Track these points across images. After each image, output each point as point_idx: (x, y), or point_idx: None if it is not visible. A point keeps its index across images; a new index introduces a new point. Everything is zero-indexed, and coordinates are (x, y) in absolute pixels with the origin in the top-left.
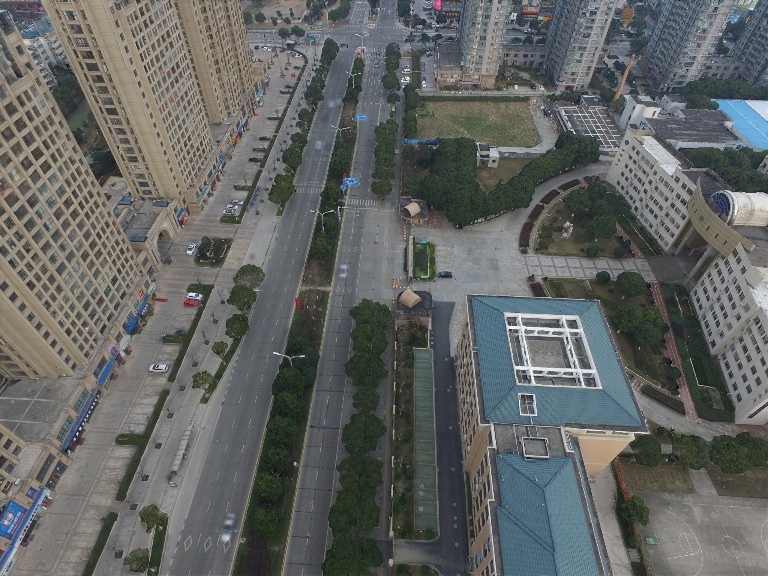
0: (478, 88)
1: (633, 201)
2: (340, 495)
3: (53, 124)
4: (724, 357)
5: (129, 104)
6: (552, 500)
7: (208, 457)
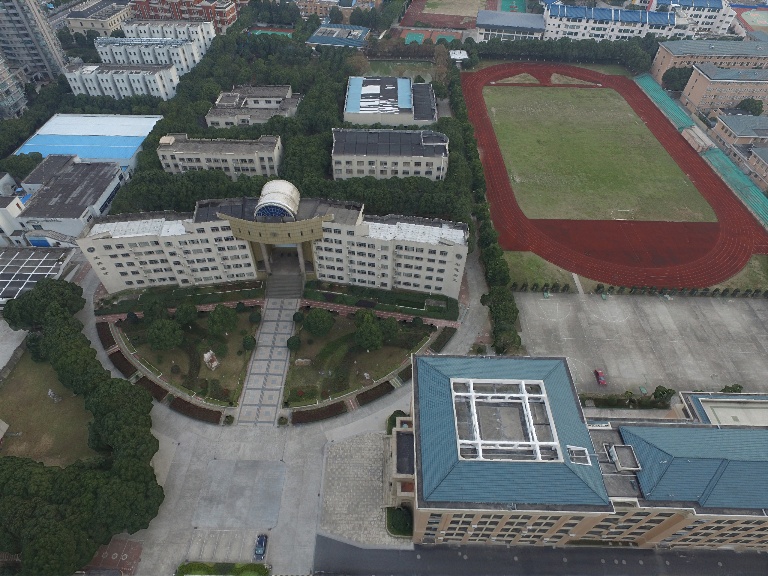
0: None
1: (169, 280)
2: None
3: None
4: (398, 283)
5: None
6: (678, 452)
7: None
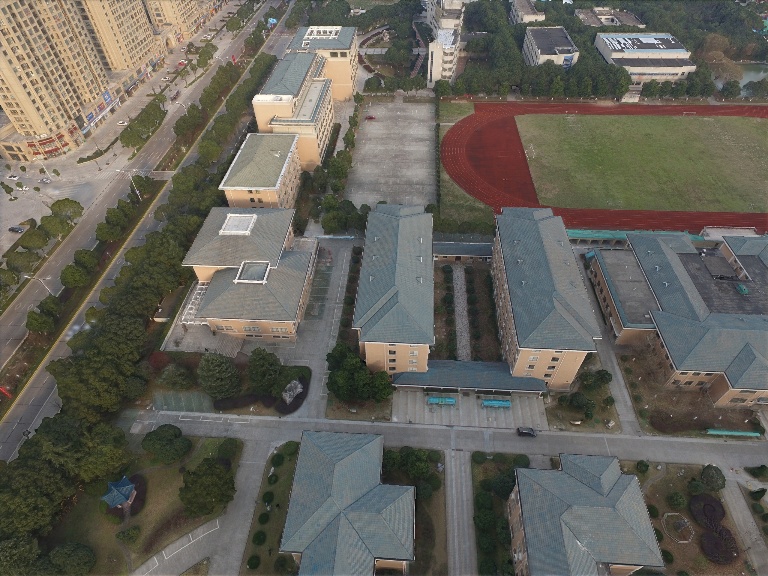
0: None
1: None
2: None
3: None
4: None
5: None
6: (300, 55)
7: (186, 99)
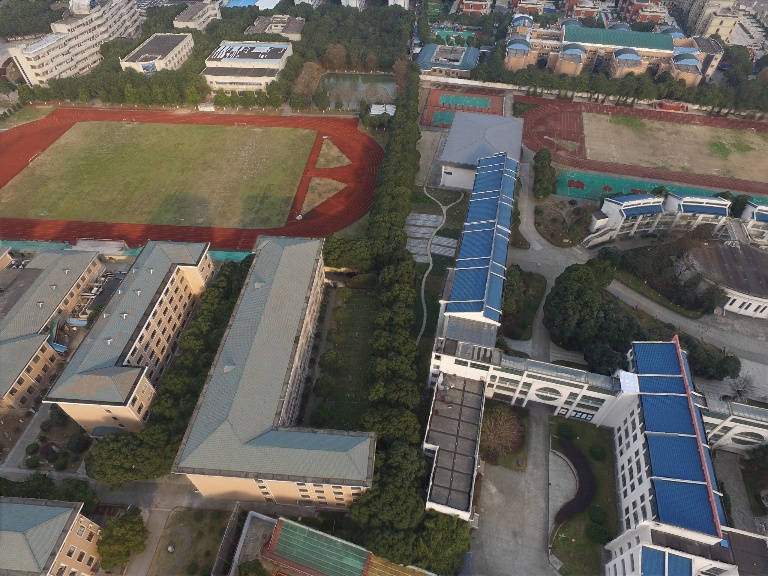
0: None
1: None
2: None
3: None
4: None
5: None
6: None
7: None
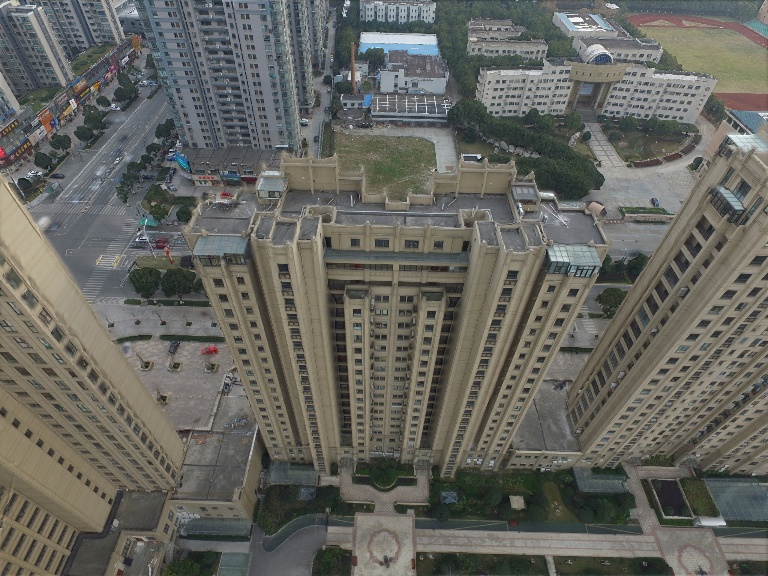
0: None
1: (513, 112)
2: None
3: None
4: (655, 115)
5: None
6: None
7: None
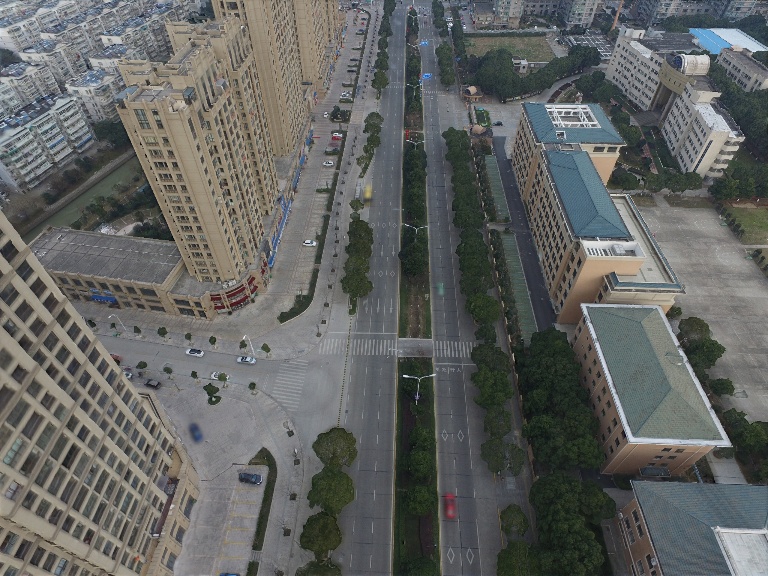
0: (506, 28)
1: (624, 87)
2: (458, 194)
3: (289, 1)
4: (680, 154)
5: (297, 10)
6: (576, 158)
7: (372, 197)
